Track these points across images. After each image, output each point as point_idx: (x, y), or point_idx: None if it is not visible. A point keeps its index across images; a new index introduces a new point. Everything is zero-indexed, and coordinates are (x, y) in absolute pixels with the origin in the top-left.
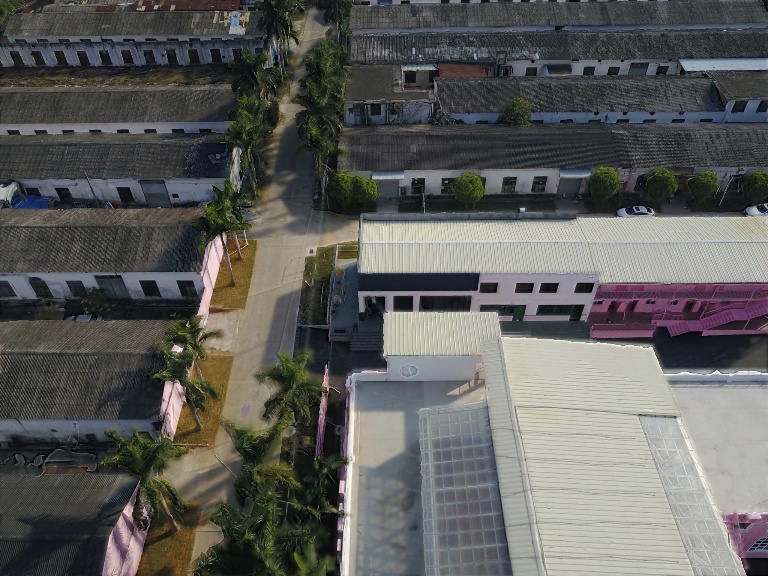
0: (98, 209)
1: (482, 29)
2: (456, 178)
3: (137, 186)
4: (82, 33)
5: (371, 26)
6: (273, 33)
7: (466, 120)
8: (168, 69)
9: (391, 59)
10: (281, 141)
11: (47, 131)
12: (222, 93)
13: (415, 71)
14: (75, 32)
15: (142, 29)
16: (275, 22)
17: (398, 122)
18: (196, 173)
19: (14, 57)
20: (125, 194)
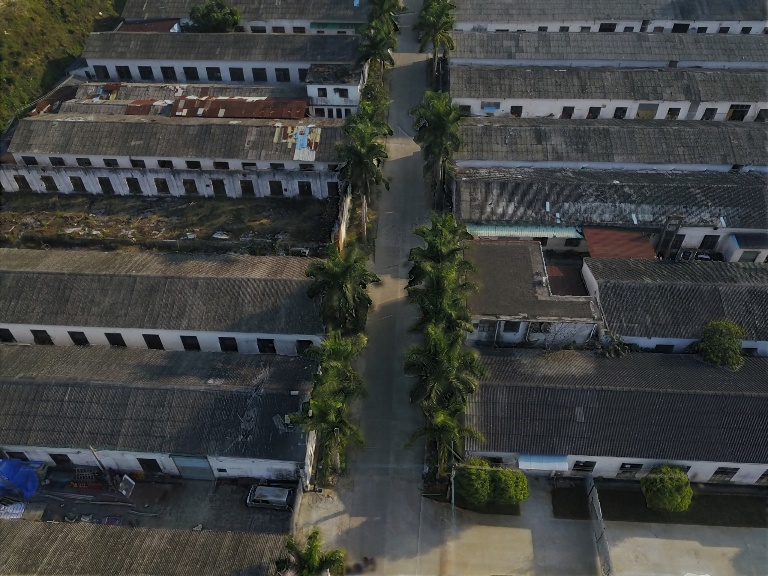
0: (106, 528)
1: (632, 165)
2: (652, 477)
3: (167, 459)
4: (106, 152)
5: (482, 156)
6: (360, 187)
7: (642, 343)
8: (213, 203)
9: (517, 219)
10: (368, 348)
11: (47, 331)
12: (290, 286)
13: (551, 237)
14: (97, 150)
15: (182, 148)
16: (364, 174)
17: (544, 346)
18: (255, 450)
19: (19, 181)
20: (149, 464)
